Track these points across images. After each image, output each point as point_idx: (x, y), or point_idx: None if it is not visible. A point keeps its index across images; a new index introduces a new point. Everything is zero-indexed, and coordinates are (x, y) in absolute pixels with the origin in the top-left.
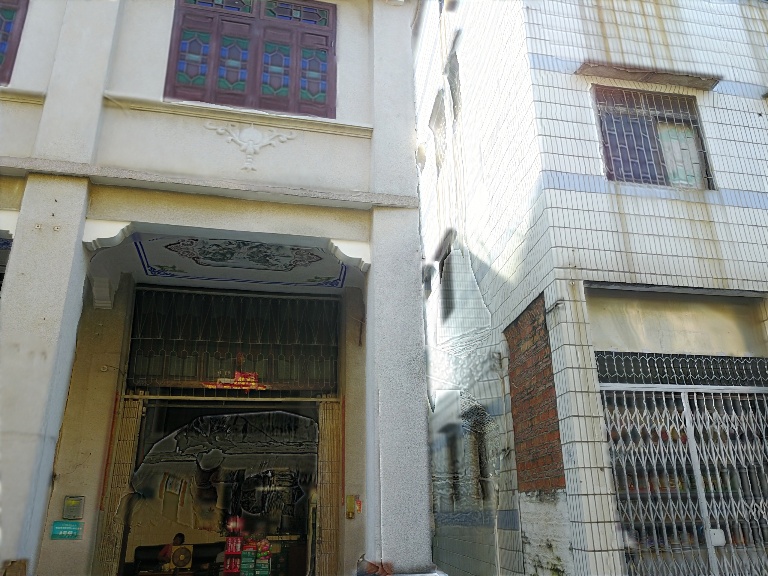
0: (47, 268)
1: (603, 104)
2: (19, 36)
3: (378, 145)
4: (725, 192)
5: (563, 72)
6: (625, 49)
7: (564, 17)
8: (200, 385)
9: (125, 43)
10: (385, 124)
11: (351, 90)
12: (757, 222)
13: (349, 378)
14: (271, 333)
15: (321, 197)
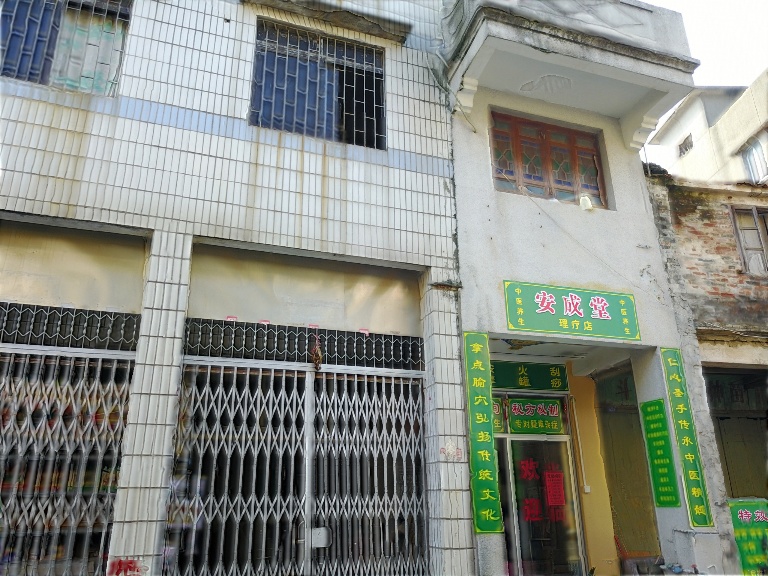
0: None
1: None
2: None
3: None
4: (127, 101)
5: None
6: None
7: None
8: None
9: None
10: None
11: None
12: (161, 142)
13: None
14: None
15: None
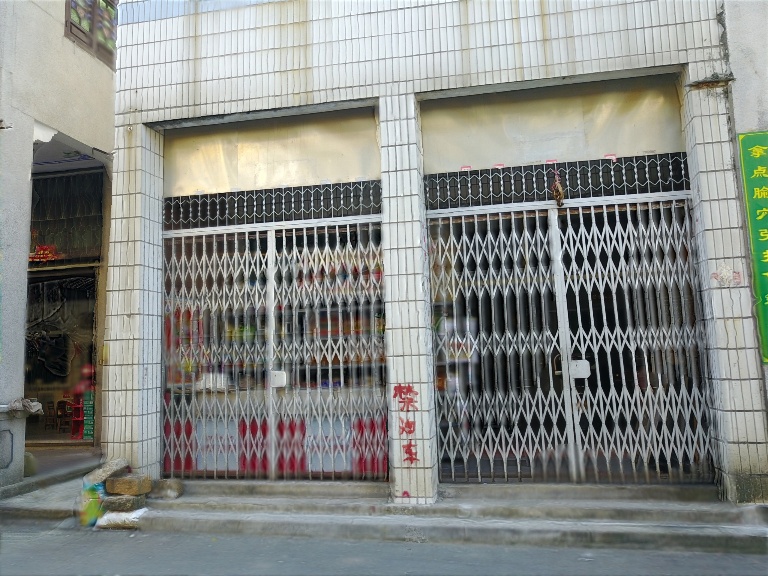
0: None
1: None
2: None
3: None
4: None
5: None
6: None
7: None
8: None
9: None
10: None
11: None
12: (372, 8)
13: (105, 243)
14: (57, 209)
15: None
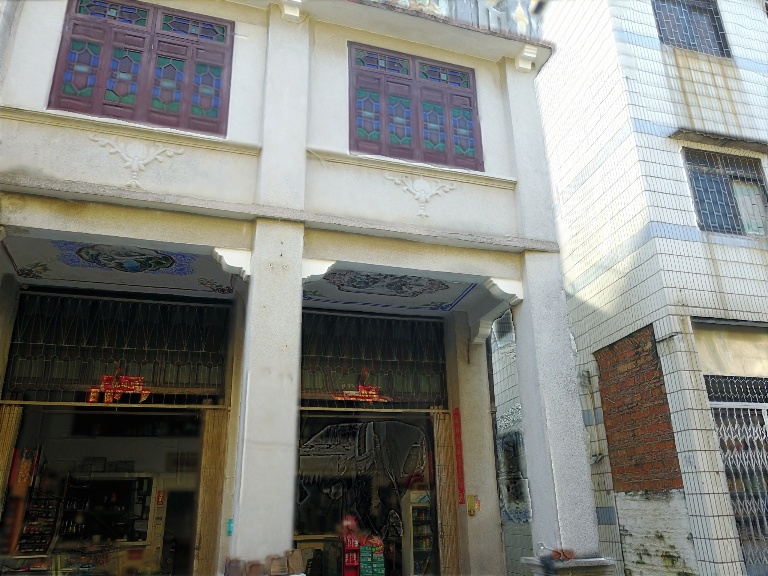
0: (283, 302)
1: (691, 164)
2: (228, 92)
3: (523, 197)
4: None
5: (659, 135)
6: (704, 116)
7: (655, 86)
8: (330, 397)
9: (314, 101)
10: (527, 178)
11: (493, 146)
12: None
13: (462, 392)
14: (388, 351)
15: (486, 242)
